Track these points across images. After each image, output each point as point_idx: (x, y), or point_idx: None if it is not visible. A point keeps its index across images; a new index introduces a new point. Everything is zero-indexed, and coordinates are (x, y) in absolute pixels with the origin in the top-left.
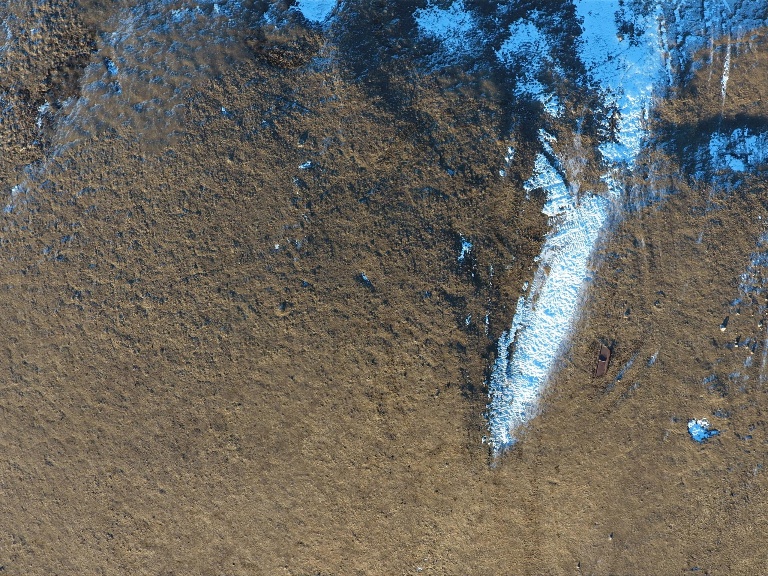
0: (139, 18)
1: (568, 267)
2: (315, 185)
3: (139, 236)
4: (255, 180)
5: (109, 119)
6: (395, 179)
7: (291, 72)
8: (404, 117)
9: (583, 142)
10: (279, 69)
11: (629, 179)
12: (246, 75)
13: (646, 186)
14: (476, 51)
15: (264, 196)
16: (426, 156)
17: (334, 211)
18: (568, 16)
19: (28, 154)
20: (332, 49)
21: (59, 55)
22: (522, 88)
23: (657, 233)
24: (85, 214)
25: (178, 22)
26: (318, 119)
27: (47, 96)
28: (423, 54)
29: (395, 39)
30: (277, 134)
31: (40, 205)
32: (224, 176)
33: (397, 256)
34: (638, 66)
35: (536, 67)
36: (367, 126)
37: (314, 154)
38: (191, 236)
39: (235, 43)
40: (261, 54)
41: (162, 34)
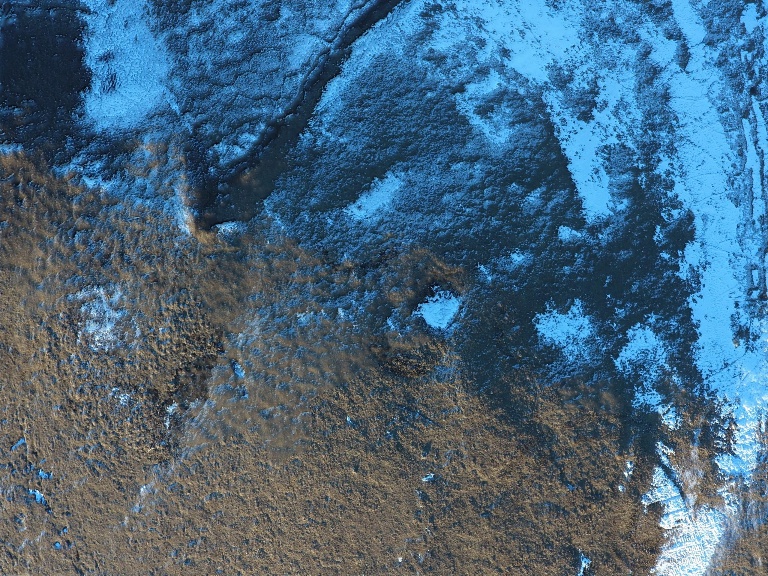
0: (265, 320)
1: None
2: (438, 499)
3: (265, 544)
4: (379, 492)
5: (236, 424)
6: (516, 493)
7: (414, 381)
8: (525, 430)
9: (700, 455)
10: (402, 378)
11: (746, 495)
12: (370, 384)
13: (763, 503)
14: (595, 360)
15: (388, 508)
16: (547, 471)
17: (456, 525)
18: (684, 321)
19: (156, 454)
20: (454, 358)
21: (187, 355)
22: (640, 399)
23: None
24: (212, 519)
25: (303, 326)
26: (441, 431)
27: (175, 397)
28: (543, 363)
29: (516, 348)
30: (401, 445)
31: (168, 507)
32: (349, 487)
33: (518, 572)
34: (754, 374)
35: (654, 376)
36: (489, 440)
37: (437, 466)
38: (316, 547)
39: (359, 350)
40: (385, 362)
41: (288, 339)
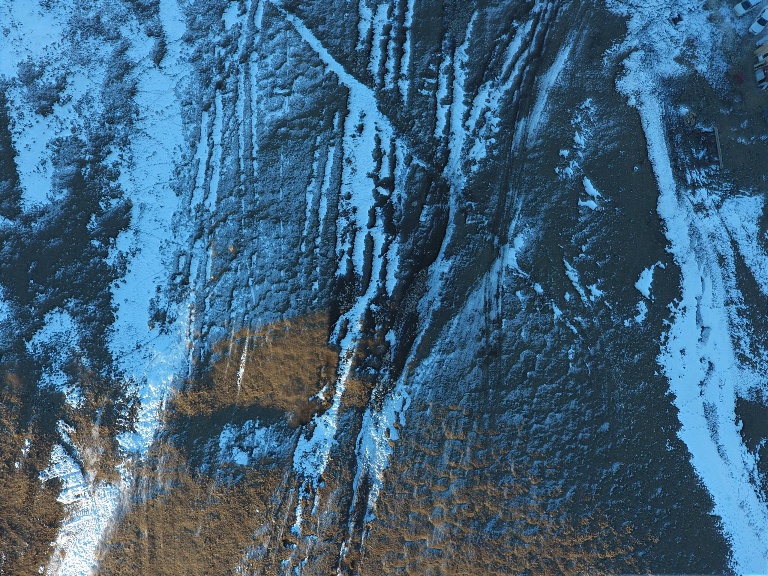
0: None
1: (79, 554)
2: None
3: None
4: None
5: None
6: None
7: None
8: None
9: (101, 432)
10: None
11: (140, 470)
12: None
13: (154, 478)
14: (6, 342)
15: None
16: None
17: None
18: (103, 304)
19: None
20: None
21: None
22: (46, 379)
23: (160, 525)
24: None
25: None
26: None
27: None
28: None
29: None
30: None
31: None
32: None
33: None
34: (164, 355)
35: (63, 358)
36: None
37: None
38: None
39: None
40: None
41: None
